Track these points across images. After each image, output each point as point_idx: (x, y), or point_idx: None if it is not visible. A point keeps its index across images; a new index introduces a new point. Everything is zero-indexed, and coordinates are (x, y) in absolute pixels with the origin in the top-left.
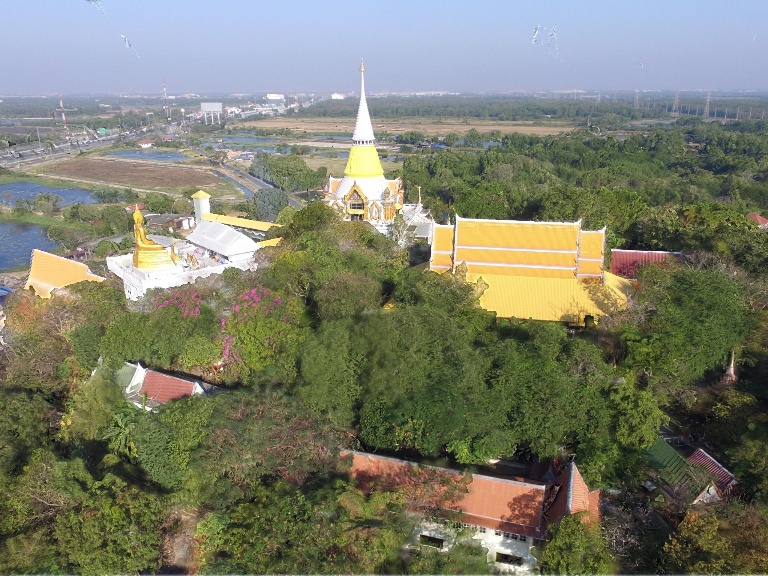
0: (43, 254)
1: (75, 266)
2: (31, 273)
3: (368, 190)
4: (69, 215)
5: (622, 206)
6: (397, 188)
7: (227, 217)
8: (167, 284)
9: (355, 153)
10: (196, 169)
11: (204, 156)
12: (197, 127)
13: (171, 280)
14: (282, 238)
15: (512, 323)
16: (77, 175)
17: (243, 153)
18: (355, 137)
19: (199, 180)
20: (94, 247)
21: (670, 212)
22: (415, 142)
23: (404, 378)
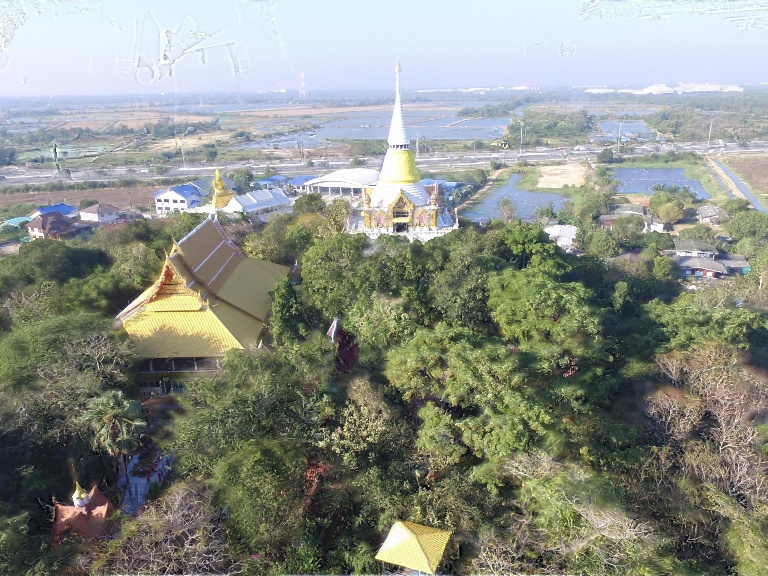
0: None
1: None
2: None
3: (374, 194)
4: None
5: (506, 304)
6: (396, 199)
7: None
8: None
9: None
10: None
11: None
12: None
13: None
14: None
15: (90, 294)
16: (741, 170)
17: None
18: None
19: None
20: None
21: (390, 313)
22: None
23: (0, 271)
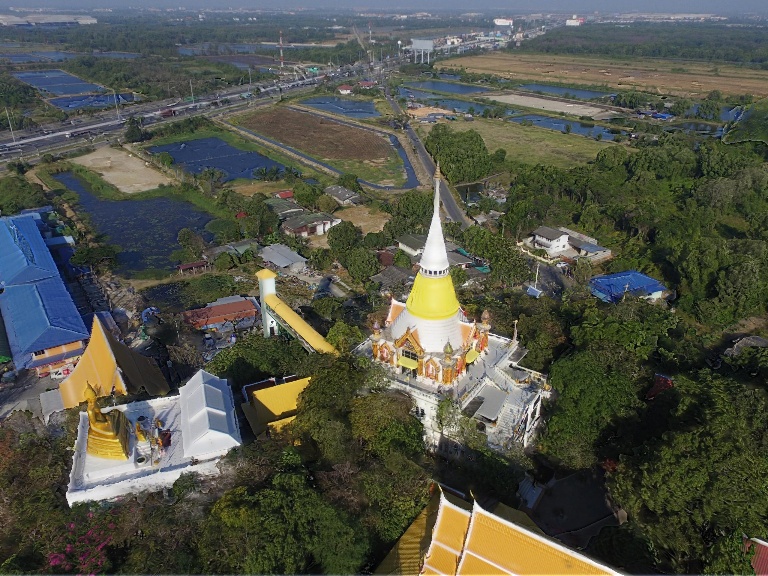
0: (98, 325)
1: (110, 357)
2: (91, 339)
3: (427, 338)
4: (220, 201)
5: None
6: (470, 336)
7: (285, 310)
8: (101, 495)
9: (418, 284)
10: (376, 132)
11: (393, 112)
12: (405, 66)
13: (106, 491)
14: (308, 385)
15: None
16: (264, 132)
17: (434, 110)
18: (422, 263)
19: (371, 151)
20: (217, 257)
21: None
22: (634, 106)
23: None
